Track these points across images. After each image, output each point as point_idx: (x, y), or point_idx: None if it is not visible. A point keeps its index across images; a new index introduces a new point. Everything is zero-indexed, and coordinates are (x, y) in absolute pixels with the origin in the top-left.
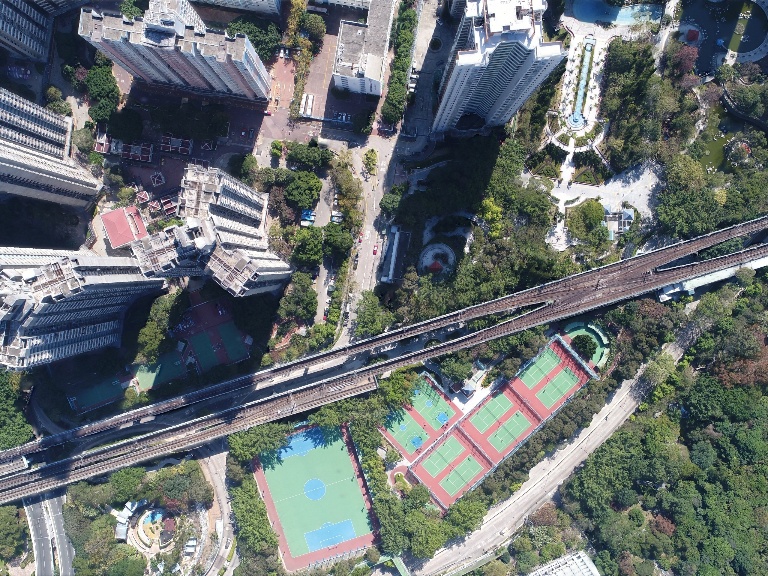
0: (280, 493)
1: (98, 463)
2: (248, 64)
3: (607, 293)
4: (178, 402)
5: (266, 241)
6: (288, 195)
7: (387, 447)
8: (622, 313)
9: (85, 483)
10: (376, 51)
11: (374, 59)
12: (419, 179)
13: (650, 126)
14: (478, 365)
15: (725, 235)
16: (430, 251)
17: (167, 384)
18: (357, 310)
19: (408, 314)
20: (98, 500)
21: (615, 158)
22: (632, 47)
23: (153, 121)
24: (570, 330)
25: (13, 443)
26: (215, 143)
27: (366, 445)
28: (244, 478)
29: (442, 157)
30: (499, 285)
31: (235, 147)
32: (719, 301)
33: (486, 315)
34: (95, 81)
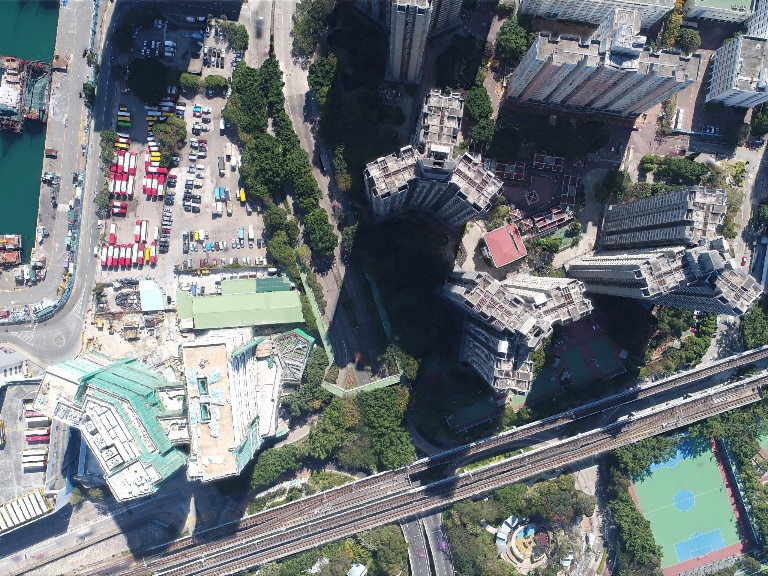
0: (649, 505)
1: (483, 480)
2: None
3: None
4: None
5: None
6: None
7: (755, 456)
8: None
9: (471, 501)
10: None
11: None
12: None
13: None
14: None
15: None
16: None
17: (549, 400)
18: (726, 321)
19: None
20: (492, 517)
21: None
22: None
23: (527, 140)
24: None
25: (402, 463)
26: (585, 159)
27: (746, 455)
28: None
29: None
30: None
31: (603, 163)
32: None
33: None
34: (476, 102)
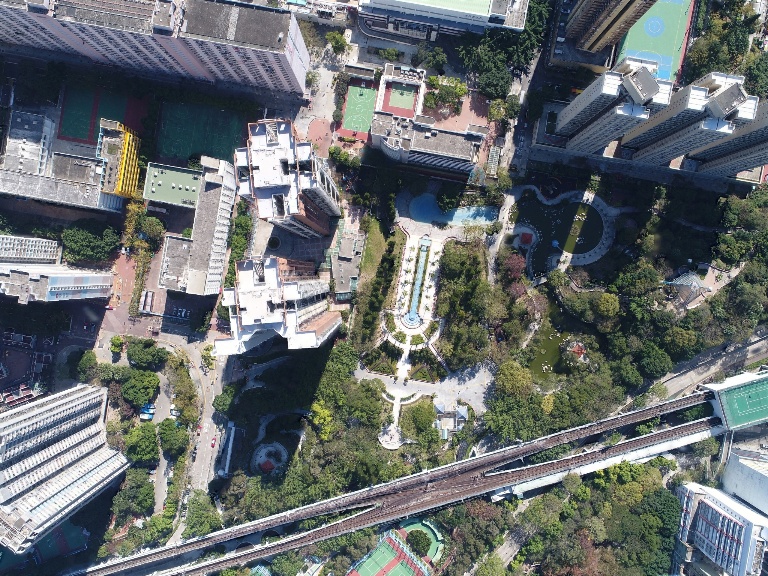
0: None
1: None
2: (58, 296)
3: (436, 496)
4: None
5: (105, 434)
6: (124, 393)
7: None
8: (450, 517)
9: None
10: (201, 265)
11: (197, 275)
12: (257, 374)
13: (477, 334)
14: (313, 559)
15: (553, 441)
16: (263, 449)
17: (4, 575)
18: None
19: (238, 514)
20: None
21: (447, 360)
22: (461, 254)
23: None
24: (405, 525)
25: None
26: (57, 337)
27: None
28: None
29: (279, 353)
30: (327, 488)
31: (78, 340)
32: (543, 510)
33: (315, 516)
34: None
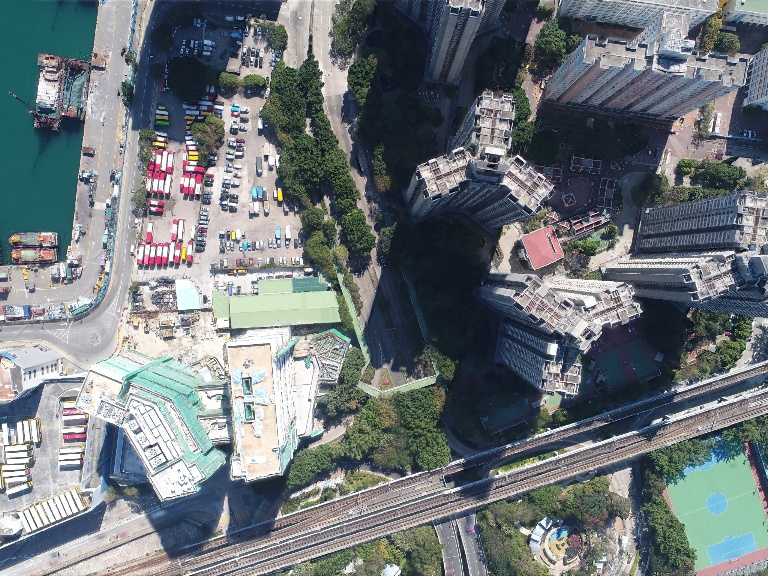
0: (682, 508)
1: (518, 482)
2: None
3: None
4: (601, 420)
5: None
6: None
7: None
8: None
9: (506, 502)
10: None
11: None
12: None
13: None
14: None
15: None
16: None
17: (585, 403)
18: (760, 325)
19: None
20: (528, 519)
21: None
22: None
23: (565, 142)
24: None
25: (438, 464)
26: (623, 162)
27: None
28: (653, 494)
29: None
30: None
31: (640, 166)
32: None
33: None
34: None
